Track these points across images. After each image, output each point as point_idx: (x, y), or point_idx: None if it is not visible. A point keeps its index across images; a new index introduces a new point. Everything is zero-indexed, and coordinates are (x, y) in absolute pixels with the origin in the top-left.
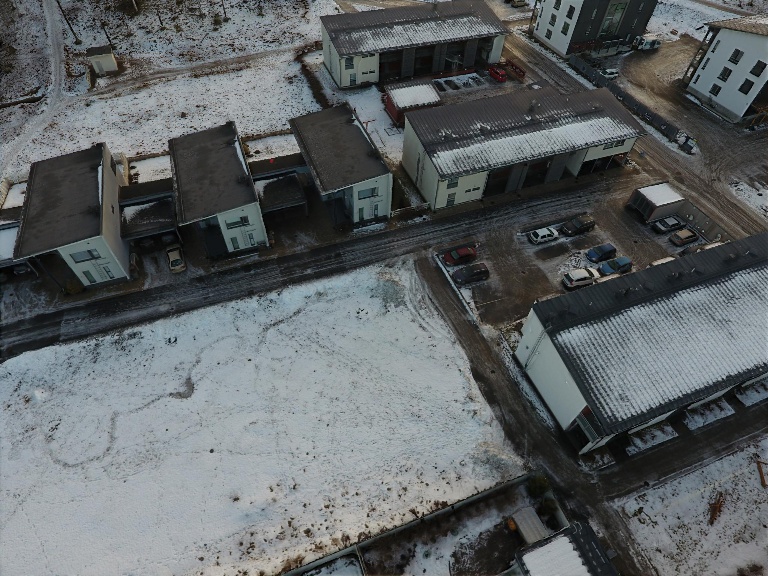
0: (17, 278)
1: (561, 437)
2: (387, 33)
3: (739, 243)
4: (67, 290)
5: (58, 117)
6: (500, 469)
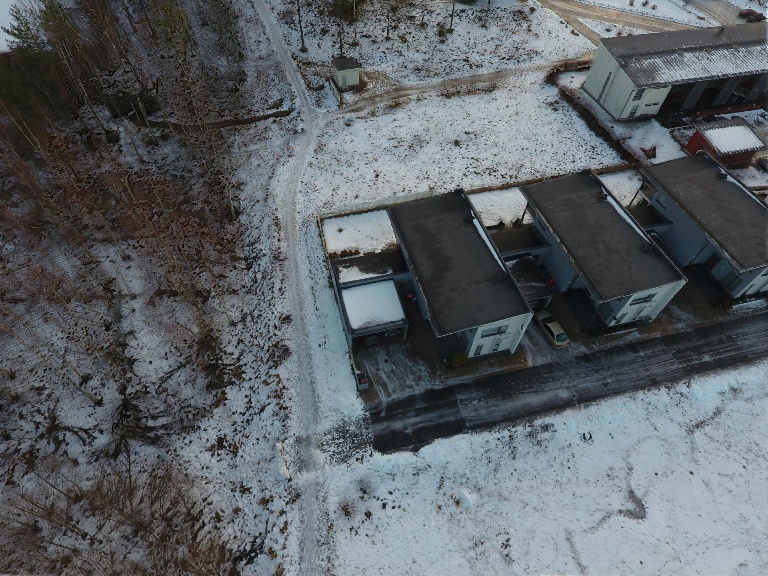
0: (383, 340)
1: None
2: (679, 61)
3: None
4: (452, 362)
5: (323, 137)
6: None
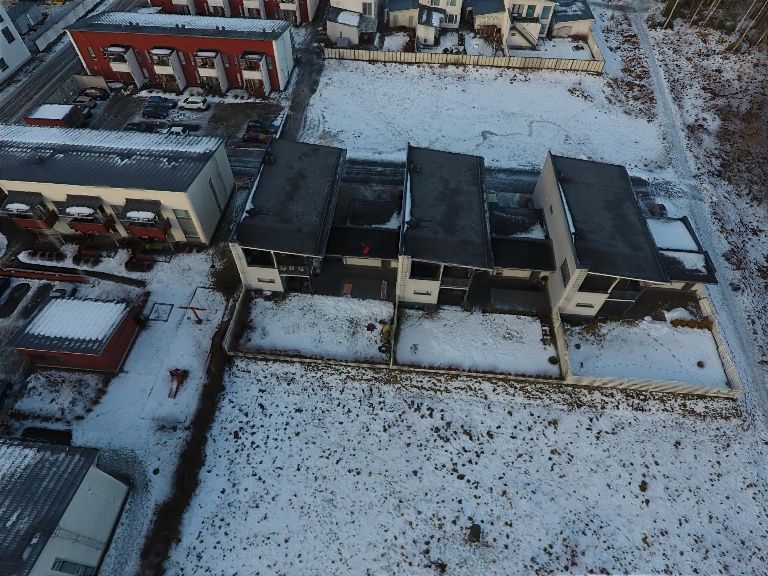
0: None
1: (298, 64)
2: None
3: (115, 30)
4: None
5: None
6: (338, 60)
